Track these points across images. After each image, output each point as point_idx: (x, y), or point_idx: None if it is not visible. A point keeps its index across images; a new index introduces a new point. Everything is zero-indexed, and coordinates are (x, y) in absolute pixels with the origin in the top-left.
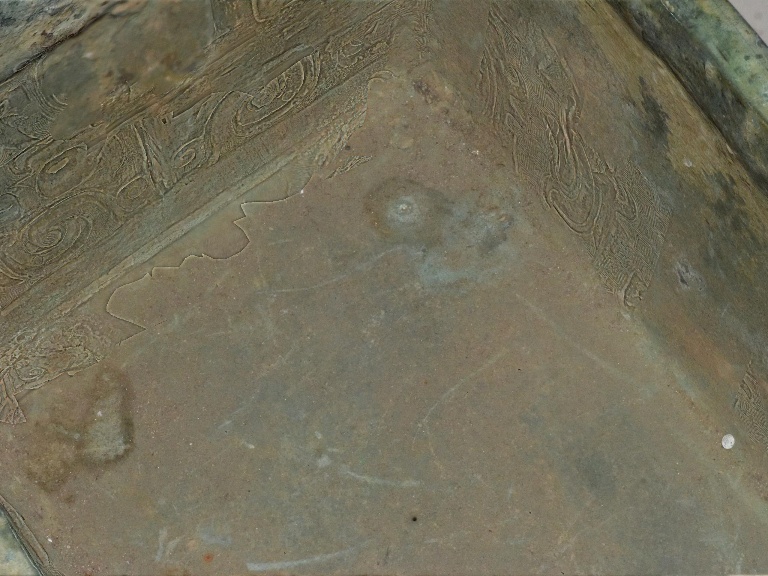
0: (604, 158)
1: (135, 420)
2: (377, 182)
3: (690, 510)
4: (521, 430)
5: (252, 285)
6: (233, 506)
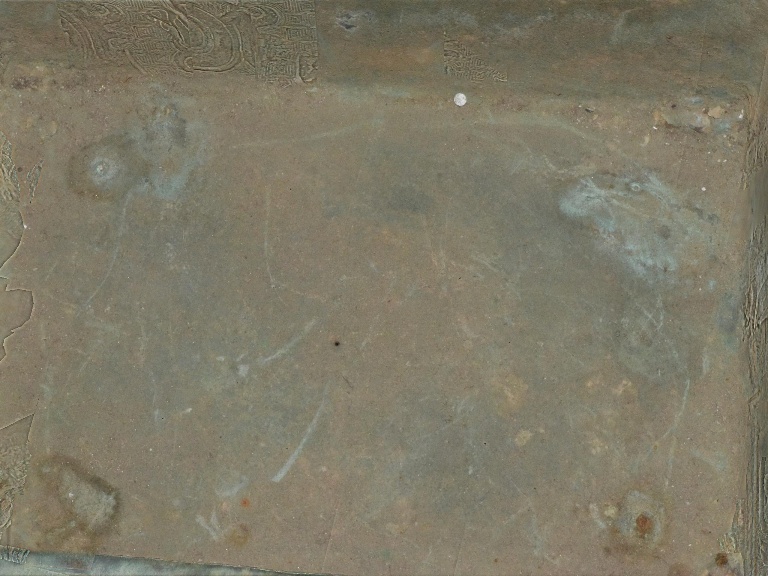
0: (224, 1)
1: (98, 474)
2: (65, 171)
3: (485, 163)
4: (335, 224)
5: (67, 316)
6: (222, 457)
